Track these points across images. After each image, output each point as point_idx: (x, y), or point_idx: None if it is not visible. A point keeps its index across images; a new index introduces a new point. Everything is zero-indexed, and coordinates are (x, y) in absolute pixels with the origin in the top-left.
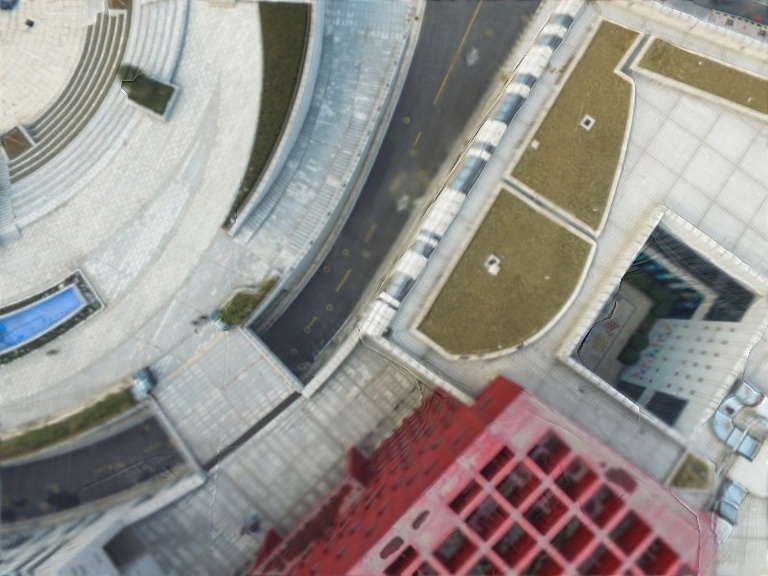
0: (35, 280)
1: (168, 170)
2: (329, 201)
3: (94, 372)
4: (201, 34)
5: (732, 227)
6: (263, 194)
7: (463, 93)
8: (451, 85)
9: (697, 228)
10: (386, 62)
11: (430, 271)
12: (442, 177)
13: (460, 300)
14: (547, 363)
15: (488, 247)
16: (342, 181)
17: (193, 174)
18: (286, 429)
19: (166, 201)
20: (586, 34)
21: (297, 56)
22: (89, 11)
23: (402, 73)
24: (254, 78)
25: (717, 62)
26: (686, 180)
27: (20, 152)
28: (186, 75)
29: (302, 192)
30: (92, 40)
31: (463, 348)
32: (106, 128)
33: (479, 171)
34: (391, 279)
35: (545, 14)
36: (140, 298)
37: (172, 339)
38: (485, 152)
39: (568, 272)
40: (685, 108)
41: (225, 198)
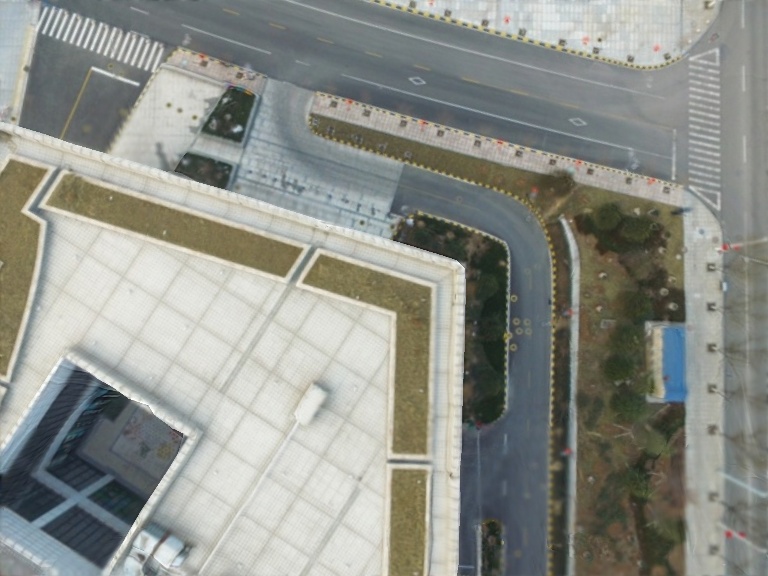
0: None
1: None
2: None
3: None
4: None
5: (156, 364)
6: None
7: None
8: None
9: (102, 371)
10: None
11: None
12: None
13: None
14: None
15: None
16: None
17: None
18: None
19: None
20: None
21: None
22: None
23: None
24: None
25: (130, 195)
26: (106, 318)
27: None
28: None
29: None
30: None
31: None
32: None
33: None
34: None
35: (144, 106)
36: None
37: None
38: None
39: None
40: (105, 243)
41: None
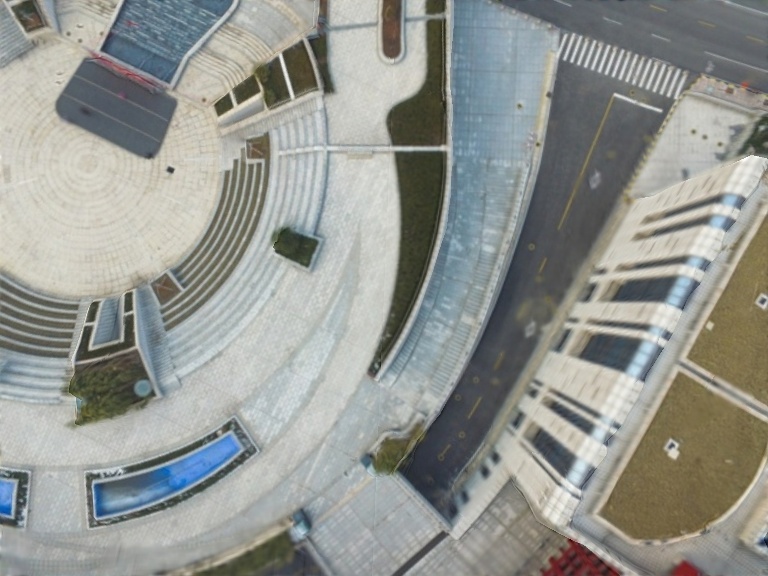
0: (195, 427)
1: (314, 318)
2: (466, 340)
3: (252, 514)
4: (341, 186)
5: None
6: (405, 339)
7: (587, 217)
8: (575, 210)
9: None
10: (510, 191)
11: (607, 455)
12: (570, 303)
13: (640, 485)
14: (729, 546)
15: (666, 431)
16: (477, 319)
17: (338, 321)
18: (435, 568)
19: (313, 348)
20: (757, 210)
21: (434, 204)
22: (225, 157)
23: (525, 200)
24: (392, 226)
25: None
26: None
27: (170, 298)
28: (328, 226)
29: (439, 331)
30: (230, 185)
31: (644, 533)
32: (252, 277)
33: (656, 358)
34: (569, 464)
35: (668, 133)
36: (292, 442)
37: (323, 481)
38: (661, 339)
39: (749, 455)
40: None
41: (369, 344)
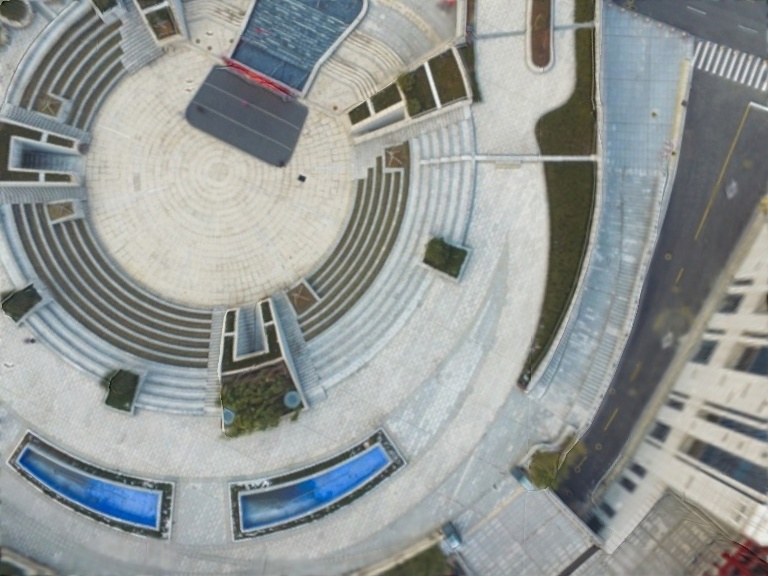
0: (341, 439)
1: (461, 329)
2: (612, 351)
3: (400, 527)
4: (488, 196)
5: None
6: None
7: (725, 227)
8: (712, 219)
9: None
10: (648, 201)
11: None
12: (708, 314)
13: None
14: None
15: None
16: (623, 330)
17: (486, 333)
18: None
19: (461, 360)
20: None
21: (585, 214)
22: (358, 165)
23: (661, 209)
24: (541, 236)
25: None
26: None
27: (307, 307)
28: (475, 236)
29: (584, 342)
30: (364, 194)
31: None
32: (396, 287)
33: None
34: None
35: None
36: (440, 455)
37: (472, 494)
38: None
39: None
40: None
41: (518, 355)
